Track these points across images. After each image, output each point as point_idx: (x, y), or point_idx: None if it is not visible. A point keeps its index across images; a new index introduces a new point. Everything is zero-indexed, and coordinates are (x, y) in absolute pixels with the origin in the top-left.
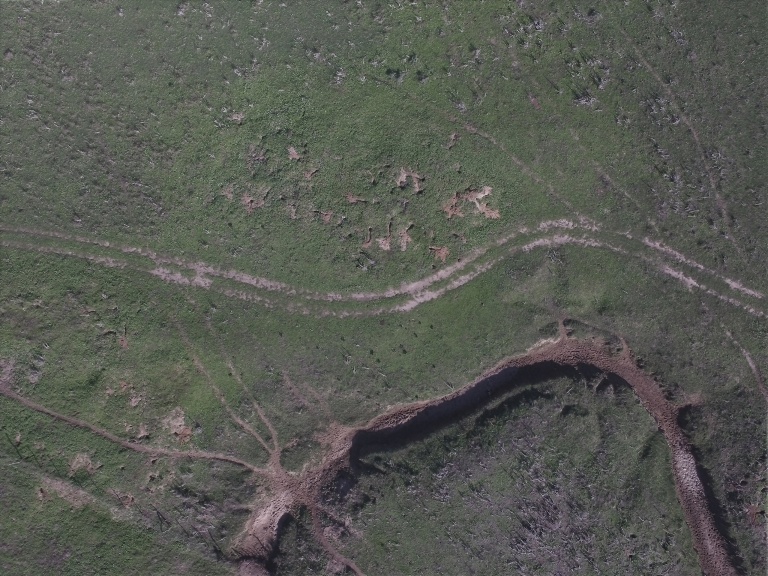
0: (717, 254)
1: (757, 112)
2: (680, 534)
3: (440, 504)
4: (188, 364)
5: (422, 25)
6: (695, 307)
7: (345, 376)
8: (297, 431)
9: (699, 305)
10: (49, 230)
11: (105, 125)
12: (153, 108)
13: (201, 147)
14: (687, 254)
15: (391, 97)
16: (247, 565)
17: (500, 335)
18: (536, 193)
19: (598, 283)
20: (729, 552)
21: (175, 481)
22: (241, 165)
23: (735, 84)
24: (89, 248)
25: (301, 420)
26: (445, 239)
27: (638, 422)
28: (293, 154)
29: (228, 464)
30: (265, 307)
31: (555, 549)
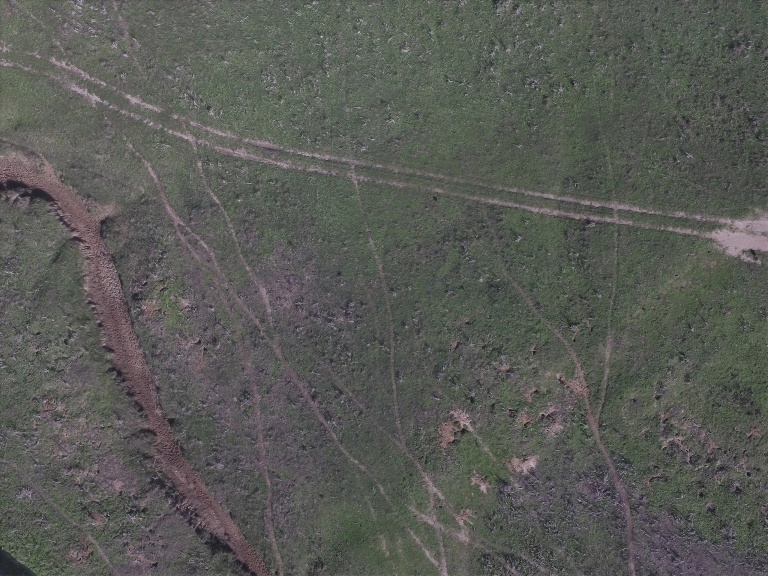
0: (117, 71)
1: None
2: (84, 331)
3: None
4: None
5: None
6: (99, 121)
7: None
8: None
9: (102, 119)
10: None
11: None
12: None
13: None
14: (90, 72)
15: None
16: None
17: None
18: None
19: (10, 100)
20: None
21: None
22: None
23: None
24: None
25: None
26: None
27: (47, 229)
28: None
29: None
30: None
31: None
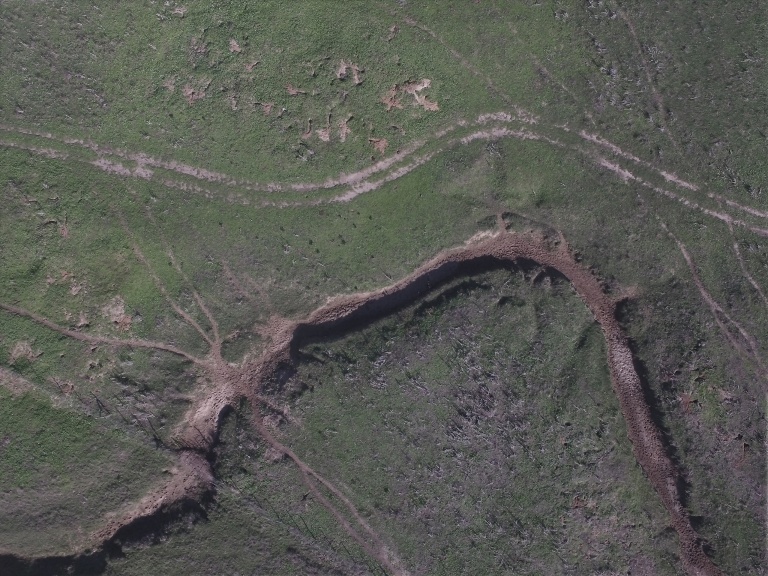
0: (653, 146)
1: (694, 8)
2: (614, 423)
3: (377, 392)
4: (128, 253)
5: None
6: (631, 199)
7: (284, 266)
8: (238, 323)
9: (635, 197)
10: None
11: (48, 18)
12: (96, 2)
13: (143, 40)
14: (623, 147)
15: None
16: (188, 456)
17: (438, 226)
18: (475, 86)
19: (536, 175)
20: (664, 443)
21: (115, 370)
22: (183, 57)
23: None
24: (31, 139)
25: (242, 311)
26: (384, 131)
27: (574, 312)
28: (234, 46)
29: (168, 354)
30: (205, 197)
31: (491, 437)
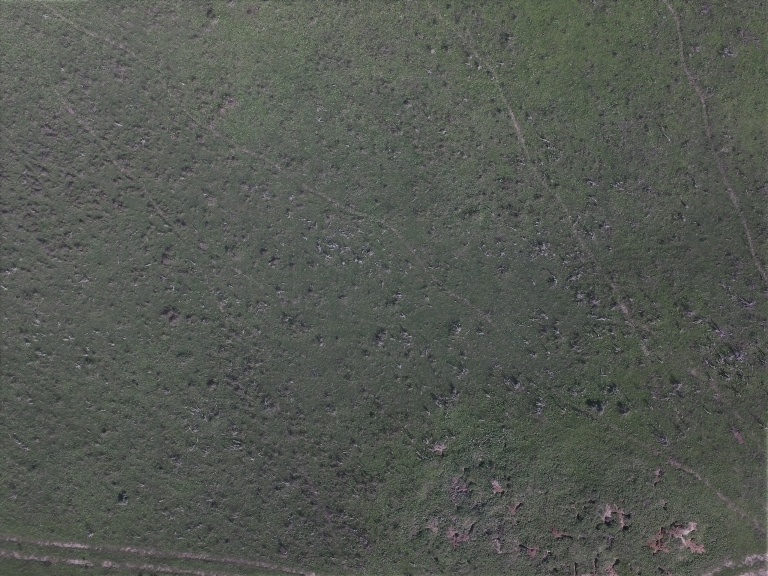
0: None
1: None
2: None
3: None
4: None
5: (621, 355)
6: None
7: None
8: None
9: None
10: (255, 560)
11: (308, 455)
12: (355, 438)
13: (404, 479)
14: None
15: (592, 429)
16: None
17: None
18: (741, 528)
19: None
20: None
21: None
22: (445, 498)
23: None
24: None
25: None
26: (651, 574)
27: None
28: (497, 488)
29: None
30: None
31: None
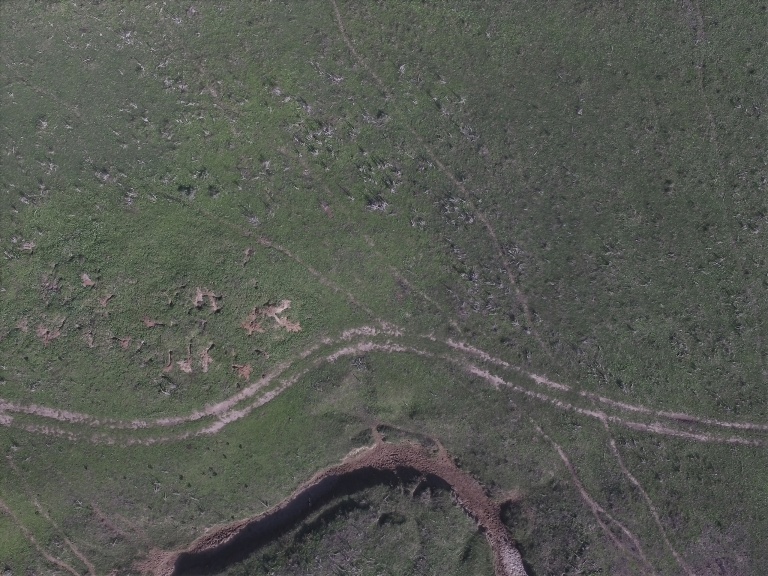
0: (521, 350)
1: (552, 203)
2: None
3: None
4: None
5: (211, 139)
6: (503, 405)
7: (156, 504)
8: (115, 561)
9: (507, 402)
10: None
11: None
12: None
13: None
14: (491, 352)
15: (184, 215)
16: None
17: (311, 448)
18: (336, 302)
19: (406, 388)
20: None
21: None
22: (34, 296)
23: (529, 177)
24: None
25: (117, 550)
26: (247, 356)
27: (455, 525)
28: (86, 281)
29: None
30: (68, 440)
31: None
